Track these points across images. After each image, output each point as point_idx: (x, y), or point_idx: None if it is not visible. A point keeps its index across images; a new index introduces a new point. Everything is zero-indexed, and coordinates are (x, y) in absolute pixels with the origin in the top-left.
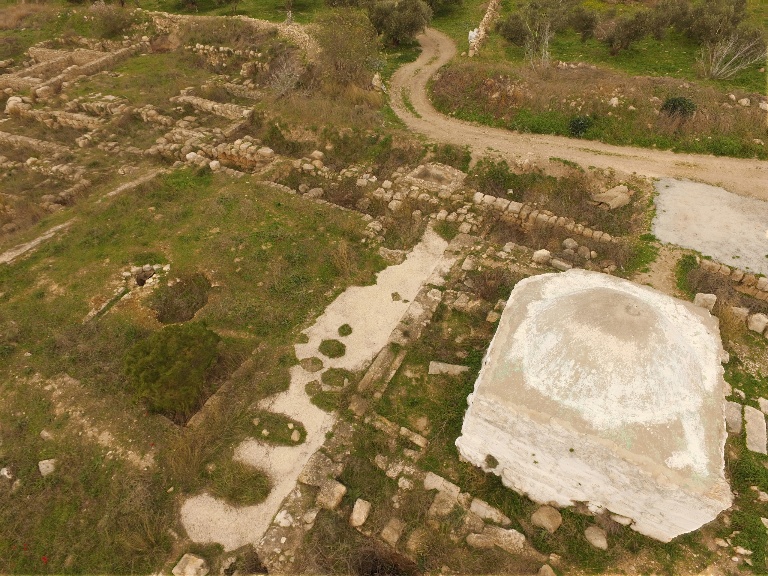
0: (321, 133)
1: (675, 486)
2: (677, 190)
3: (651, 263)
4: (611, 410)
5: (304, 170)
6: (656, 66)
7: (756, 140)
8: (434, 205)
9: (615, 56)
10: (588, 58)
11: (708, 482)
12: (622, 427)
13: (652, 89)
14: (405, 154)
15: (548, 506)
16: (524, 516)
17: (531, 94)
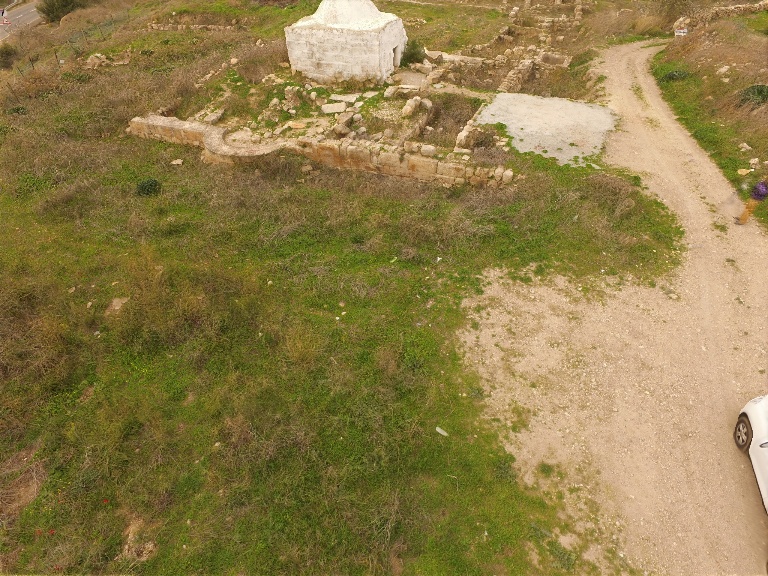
0: None
1: None
2: (586, 108)
3: (468, 89)
4: None
5: None
6: None
7: (743, 143)
8: None
9: None
10: None
11: None
12: None
13: None
14: None
15: None
16: None
17: None
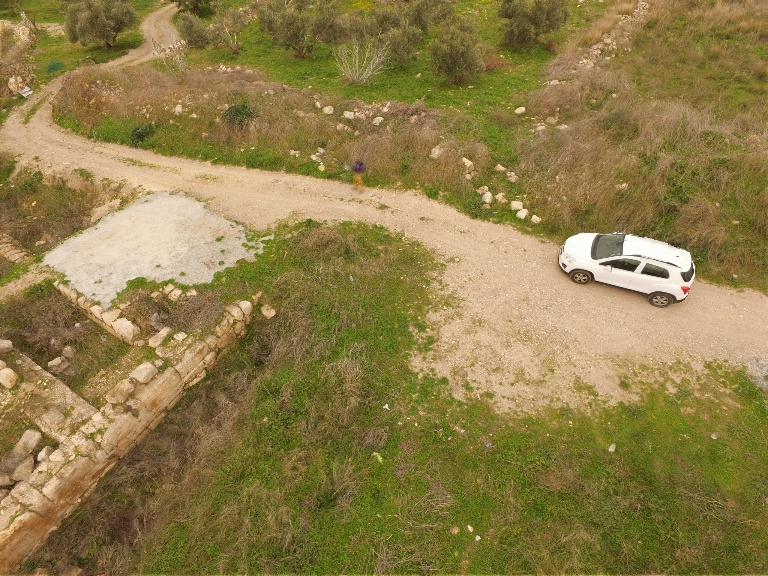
0: None
1: None
2: (148, 205)
3: None
4: None
5: None
6: (323, 70)
7: (291, 151)
8: None
9: (296, 60)
10: (272, 62)
11: None
12: None
13: (231, 96)
14: None
15: None
16: None
17: None
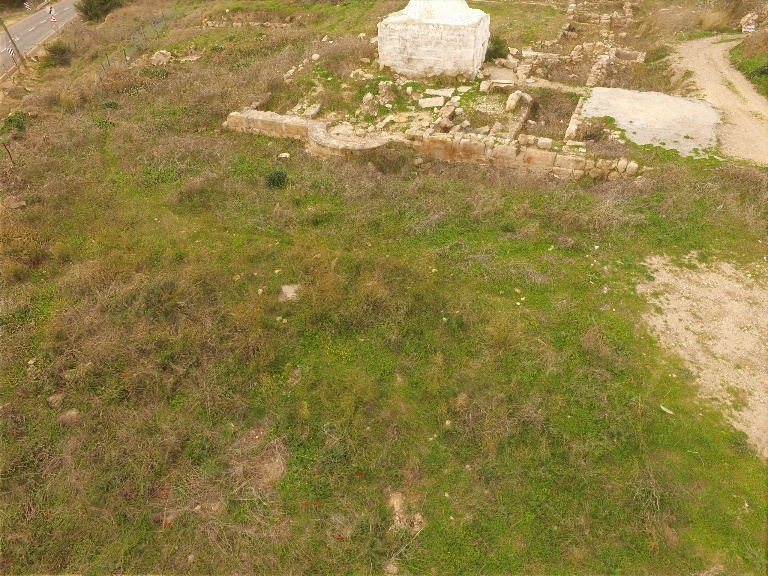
0: None
1: None
2: (687, 102)
3: (561, 84)
4: None
5: None
6: None
7: None
8: None
9: None
10: None
11: None
12: None
13: None
14: None
15: None
16: None
17: None
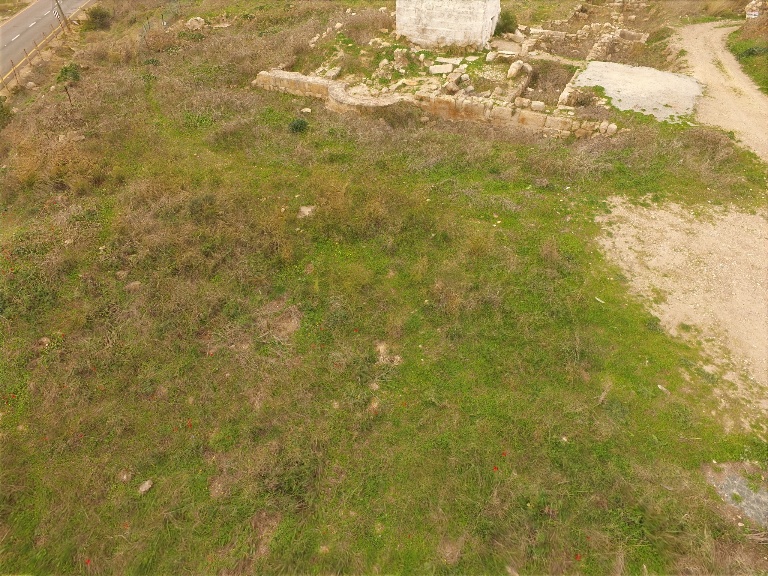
0: None
1: None
2: (674, 77)
3: (562, 57)
4: None
5: None
6: None
7: None
8: None
9: None
10: None
11: None
12: None
13: None
14: None
15: None
16: None
17: None
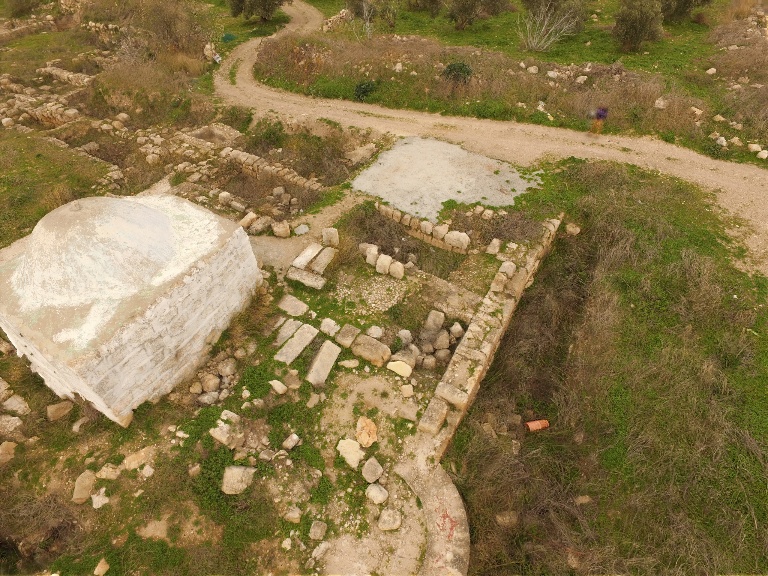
0: (134, 97)
1: (49, 356)
2: (411, 147)
3: (326, 206)
4: (36, 295)
5: (103, 130)
6: (490, 40)
7: (518, 103)
8: (194, 160)
9: (458, 31)
10: (434, 33)
11: (78, 353)
12: (38, 309)
13: (442, 56)
14: (197, 116)
15: (67, 401)
16: (42, 408)
17: (331, 61)
